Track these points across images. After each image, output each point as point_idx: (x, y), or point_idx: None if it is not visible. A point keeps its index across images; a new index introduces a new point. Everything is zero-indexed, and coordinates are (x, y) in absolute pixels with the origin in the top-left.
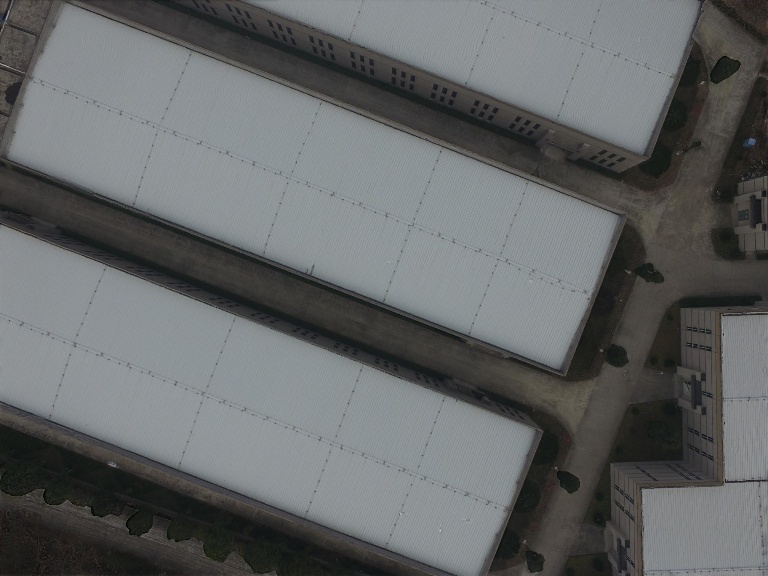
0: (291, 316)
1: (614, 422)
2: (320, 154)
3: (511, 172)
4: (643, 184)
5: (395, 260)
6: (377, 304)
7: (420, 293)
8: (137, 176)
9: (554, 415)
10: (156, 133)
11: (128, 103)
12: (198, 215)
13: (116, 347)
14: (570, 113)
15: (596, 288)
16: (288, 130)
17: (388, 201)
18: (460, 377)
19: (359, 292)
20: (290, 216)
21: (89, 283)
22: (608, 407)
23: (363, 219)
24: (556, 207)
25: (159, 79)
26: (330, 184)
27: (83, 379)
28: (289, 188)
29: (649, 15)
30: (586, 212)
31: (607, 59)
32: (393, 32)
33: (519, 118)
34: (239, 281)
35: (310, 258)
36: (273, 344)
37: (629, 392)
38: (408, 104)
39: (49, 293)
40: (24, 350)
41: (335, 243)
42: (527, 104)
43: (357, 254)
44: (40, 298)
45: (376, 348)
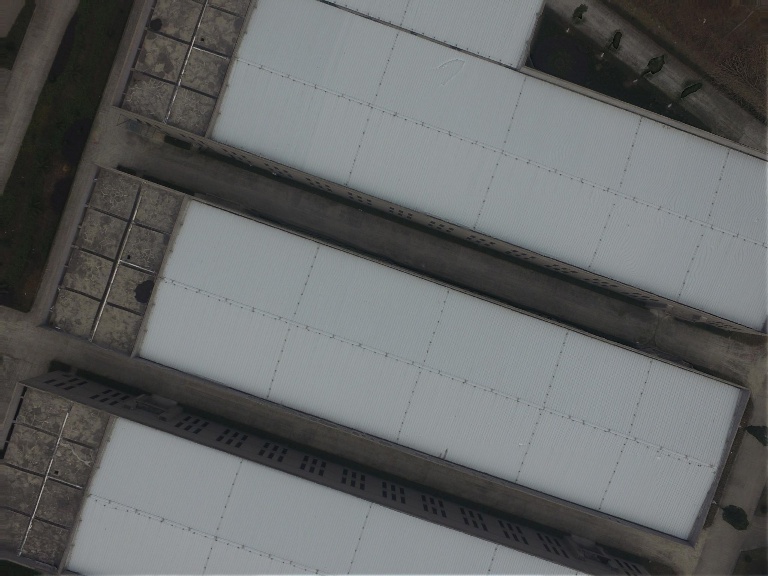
0: (412, 481)
1: (727, 569)
2: (450, 342)
3: (636, 351)
4: (749, 339)
5: (526, 442)
6: (512, 487)
7: (551, 472)
8: (270, 370)
9: (669, 565)
10: (289, 328)
11: (260, 299)
12: (332, 405)
13: (257, 539)
14: (693, 295)
15: (722, 462)
16: (418, 319)
17: (518, 386)
18: (578, 533)
19: (492, 474)
20: (423, 404)
21: (227, 476)
22: (721, 555)
23: (495, 404)
24: (680, 384)
25: (289, 274)
26: (461, 372)
27: (225, 571)
28: (421, 377)
29: (767, 197)
30: (709, 387)
31: (726, 240)
32: (520, 223)
33: (638, 294)
34: (360, 449)
35: (443, 443)
36: (410, 528)
37: (740, 540)
38: (520, 270)
39: (188, 489)
40: (165, 546)
41: (467, 428)
42: (649, 285)
43: (489, 438)
44: (179, 494)
45: (496, 509)
